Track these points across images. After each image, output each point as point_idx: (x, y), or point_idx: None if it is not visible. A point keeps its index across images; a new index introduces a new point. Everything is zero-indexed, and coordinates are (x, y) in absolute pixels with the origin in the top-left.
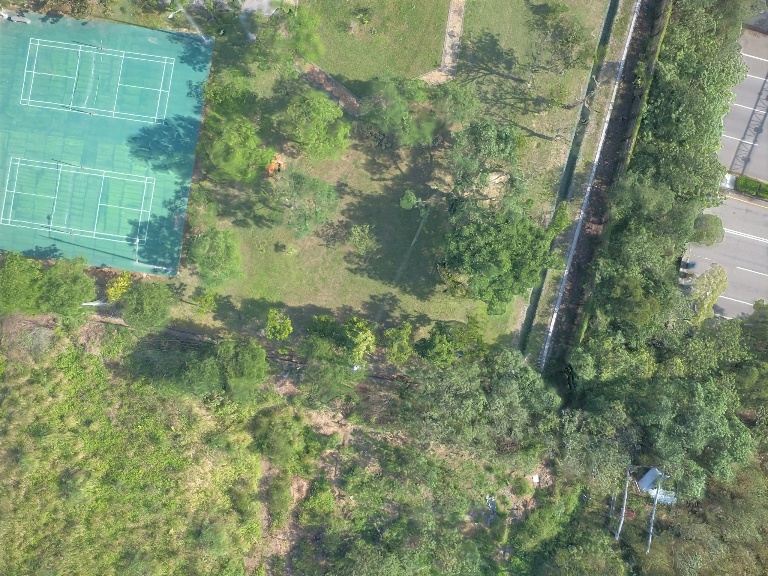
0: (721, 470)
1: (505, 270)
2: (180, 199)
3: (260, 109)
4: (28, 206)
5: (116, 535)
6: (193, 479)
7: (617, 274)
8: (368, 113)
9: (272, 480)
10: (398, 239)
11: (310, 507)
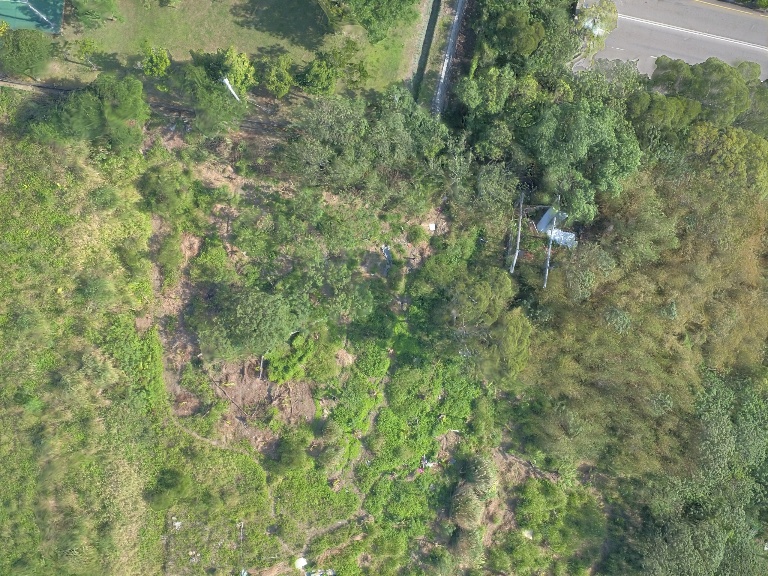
0: (609, 182)
1: None
2: None
3: None
4: None
5: (4, 297)
6: (80, 236)
7: (505, 9)
8: None
9: (163, 239)
10: None
11: (202, 263)
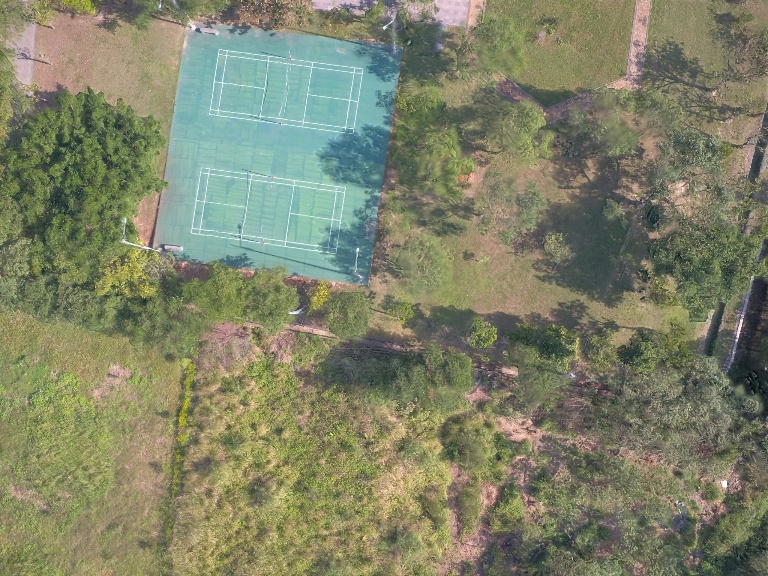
0: None
1: None
2: (371, 208)
3: (448, 118)
4: (219, 216)
5: (309, 542)
6: (386, 486)
7: None
8: (555, 122)
9: (461, 487)
10: (586, 246)
11: (501, 513)
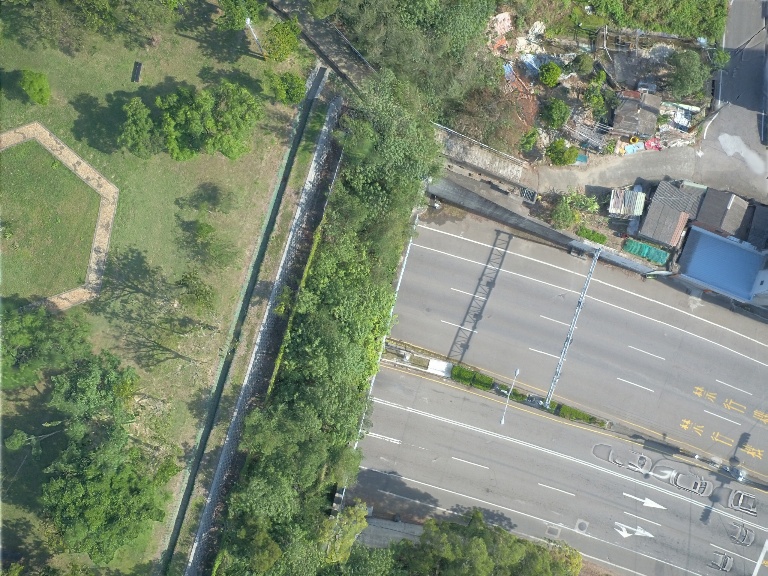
0: None
1: (97, 526)
2: None
3: None
4: None
5: None
6: None
7: (250, 510)
8: None
9: None
10: (33, 462)
11: None
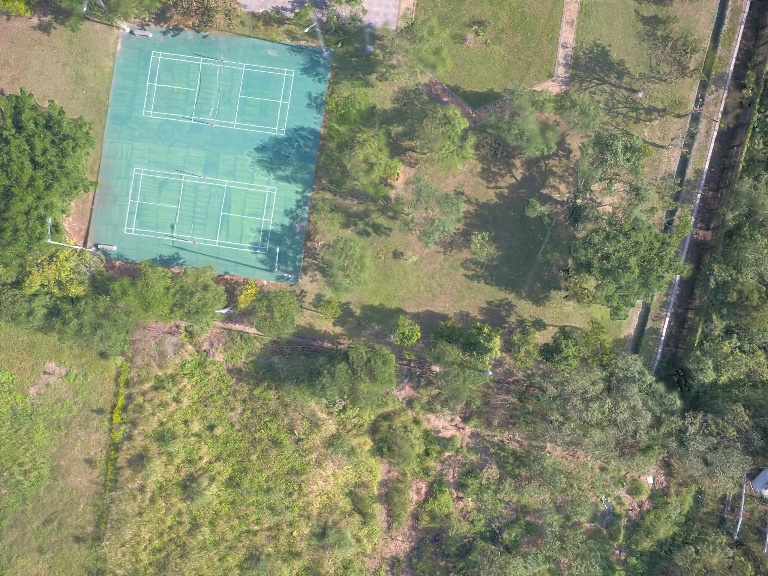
0: None
1: (633, 276)
2: (301, 208)
3: (378, 119)
4: (152, 215)
5: (240, 537)
6: (316, 482)
7: (731, 279)
8: (484, 123)
9: (391, 483)
10: (514, 246)
11: (429, 509)
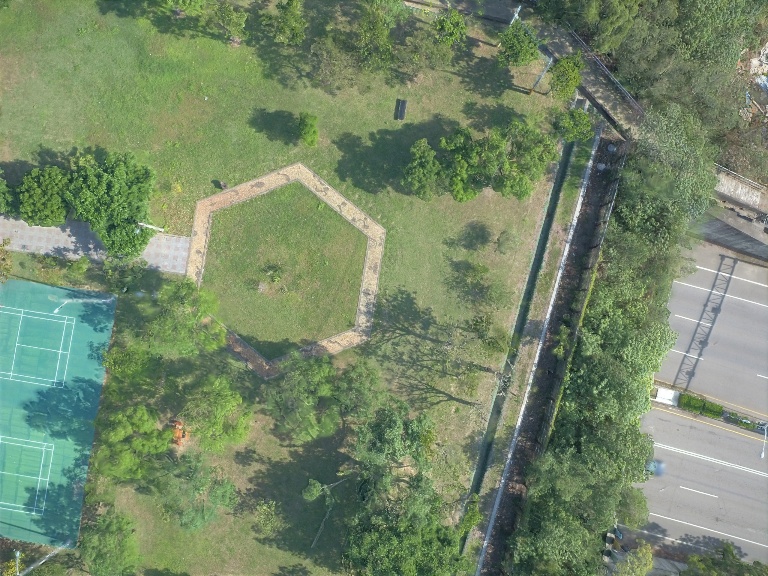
0: None
1: None
2: (80, 467)
3: (165, 371)
4: None
5: None
6: None
7: (536, 554)
8: (277, 376)
9: None
10: (309, 508)
11: None
